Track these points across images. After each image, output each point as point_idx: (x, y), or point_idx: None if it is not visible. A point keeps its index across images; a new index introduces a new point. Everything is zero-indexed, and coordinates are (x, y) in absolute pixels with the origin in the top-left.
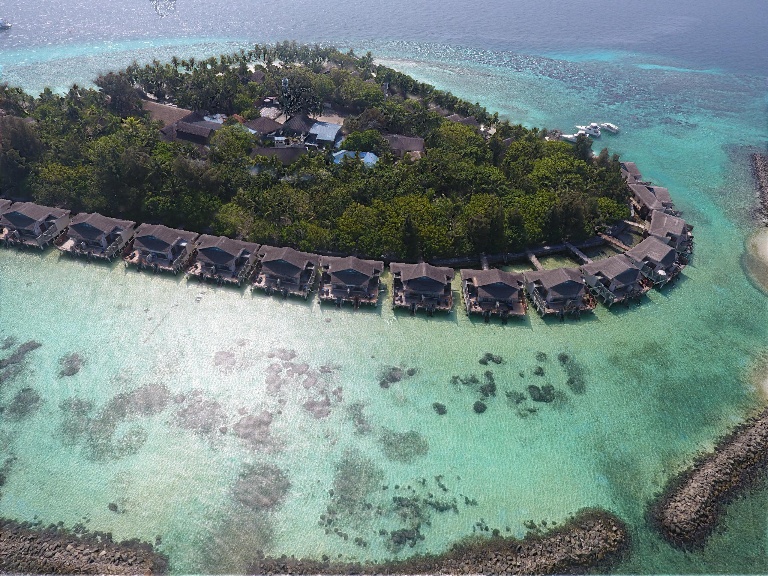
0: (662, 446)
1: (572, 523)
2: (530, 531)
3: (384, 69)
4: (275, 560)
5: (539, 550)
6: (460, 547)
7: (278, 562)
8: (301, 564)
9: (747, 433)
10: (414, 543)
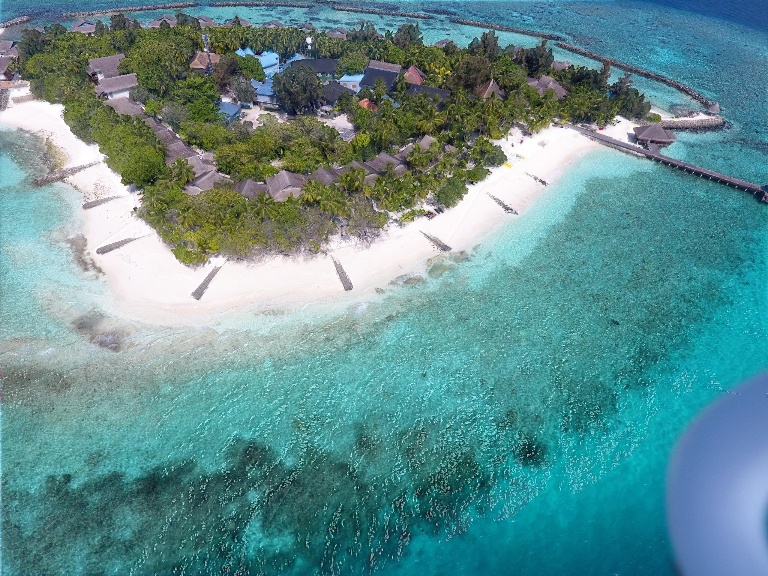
0: (177, 11)
1: (224, 6)
2: (237, 6)
3: (147, 160)
4: (306, 7)
5: (237, 3)
6: (258, 6)
7: (305, 7)
8: (299, 6)
9: (141, 8)
10: (270, 7)
